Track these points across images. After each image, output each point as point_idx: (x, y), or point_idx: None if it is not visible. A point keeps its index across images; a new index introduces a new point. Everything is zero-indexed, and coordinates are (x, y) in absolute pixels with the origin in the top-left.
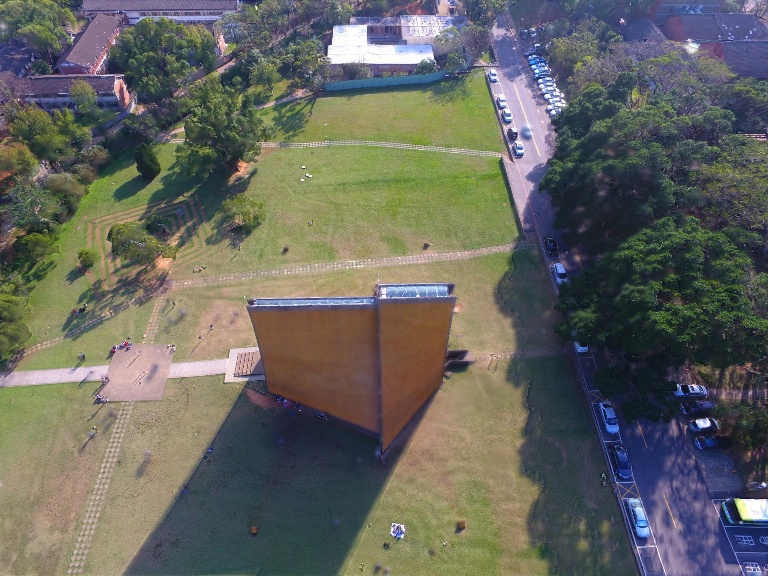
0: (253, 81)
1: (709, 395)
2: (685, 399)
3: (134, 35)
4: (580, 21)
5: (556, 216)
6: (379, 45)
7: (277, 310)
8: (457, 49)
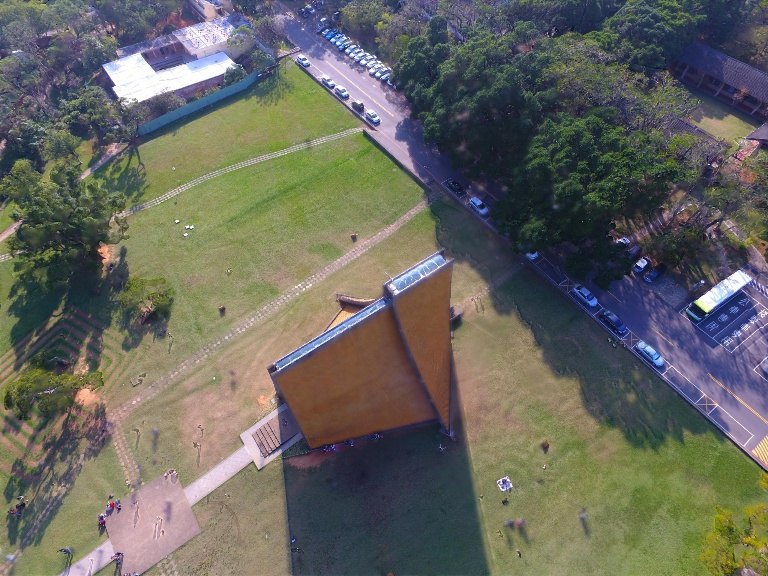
0: (50, 156)
1: (630, 242)
2: None
3: None
4: None
5: (442, 161)
6: (169, 69)
7: (302, 361)
8: (255, 46)
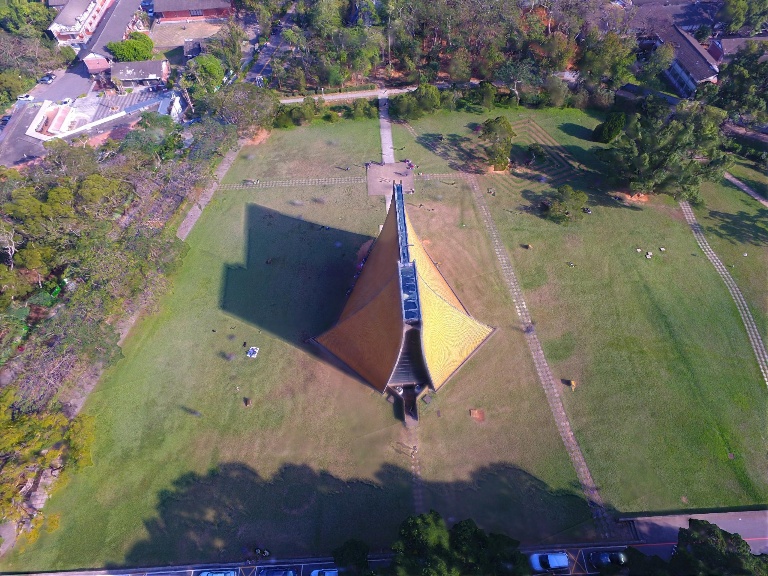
0: None
1: None
2: None
3: (766, 51)
4: None
5: None
6: None
7: None
8: None
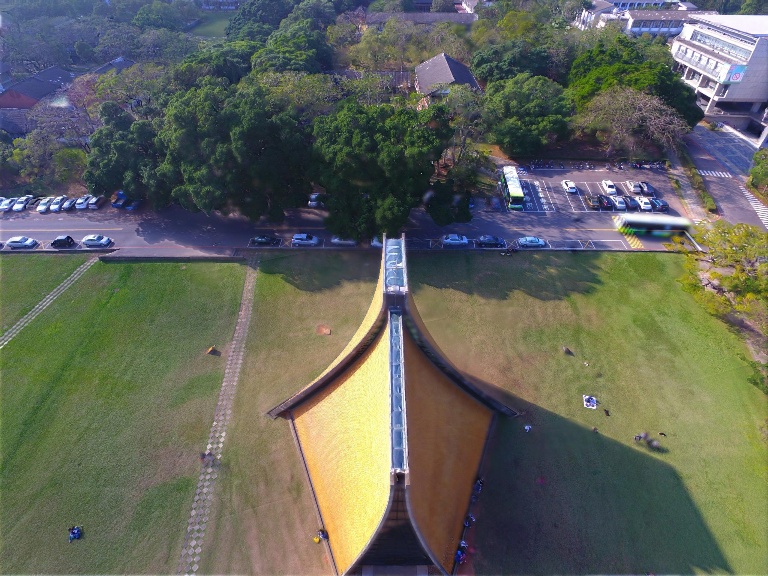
0: None
1: None
2: None
3: None
4: None
5: None
6: None
7: None
8: None
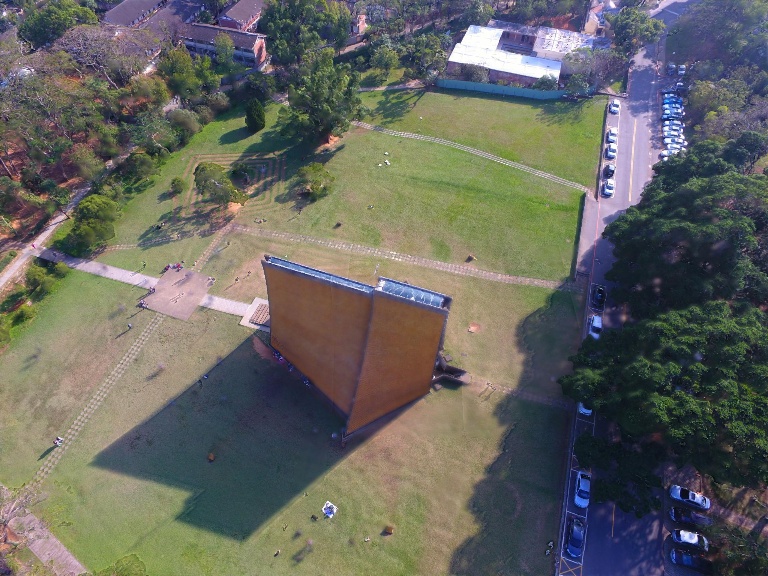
0: (373, 63)
1: (713, 511)
2: (681, 504)
3: (280, 2)
4: (737, 67)
5: None
6: (507, 52)
7: (286, 272)
8: (585, 71)
